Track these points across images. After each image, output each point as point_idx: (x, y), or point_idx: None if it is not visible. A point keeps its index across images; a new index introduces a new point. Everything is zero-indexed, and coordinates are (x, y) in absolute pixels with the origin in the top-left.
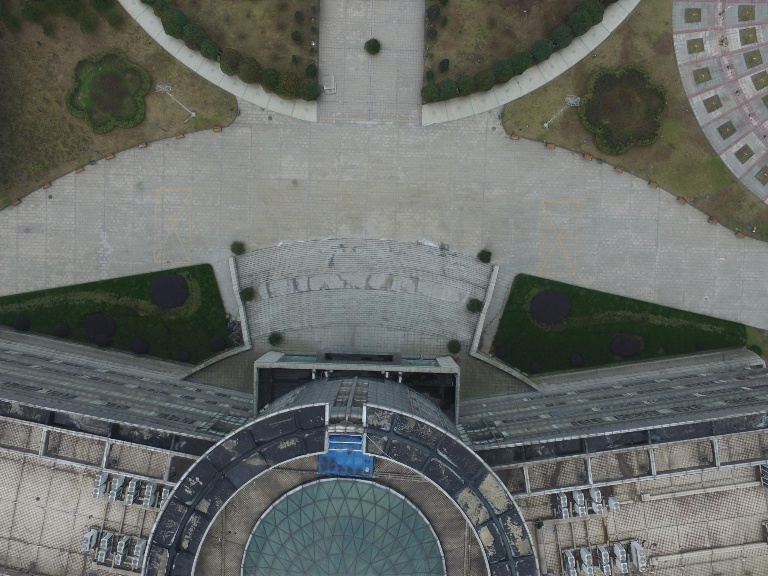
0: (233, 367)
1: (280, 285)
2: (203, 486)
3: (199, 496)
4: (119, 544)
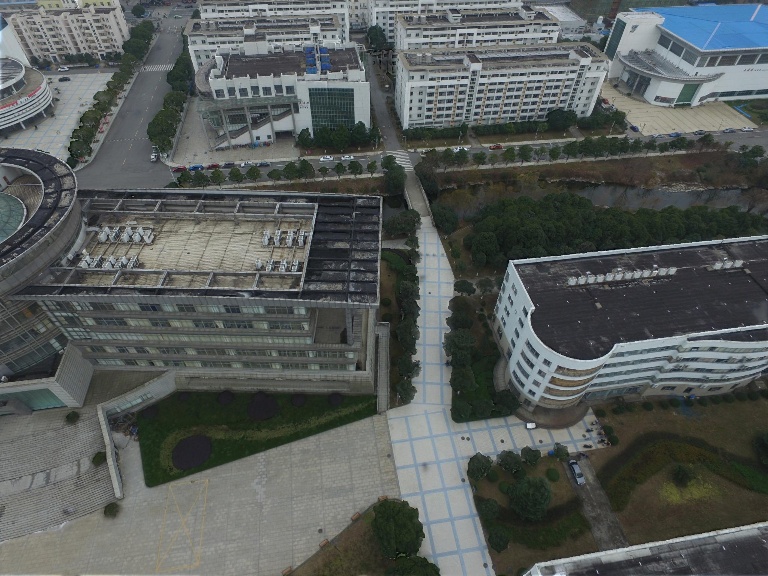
0: (122, 389)
1: (65, 475)
2: (2, 258)
3: (5, 252)
4: (124, 236)
